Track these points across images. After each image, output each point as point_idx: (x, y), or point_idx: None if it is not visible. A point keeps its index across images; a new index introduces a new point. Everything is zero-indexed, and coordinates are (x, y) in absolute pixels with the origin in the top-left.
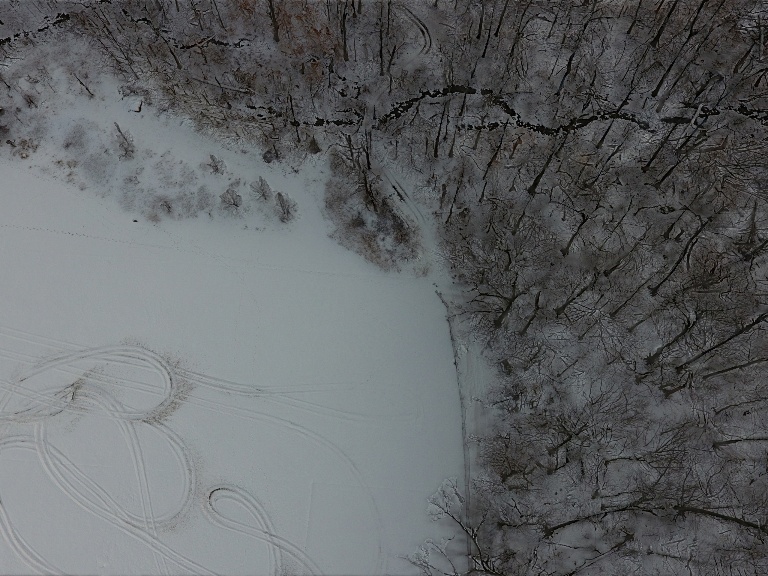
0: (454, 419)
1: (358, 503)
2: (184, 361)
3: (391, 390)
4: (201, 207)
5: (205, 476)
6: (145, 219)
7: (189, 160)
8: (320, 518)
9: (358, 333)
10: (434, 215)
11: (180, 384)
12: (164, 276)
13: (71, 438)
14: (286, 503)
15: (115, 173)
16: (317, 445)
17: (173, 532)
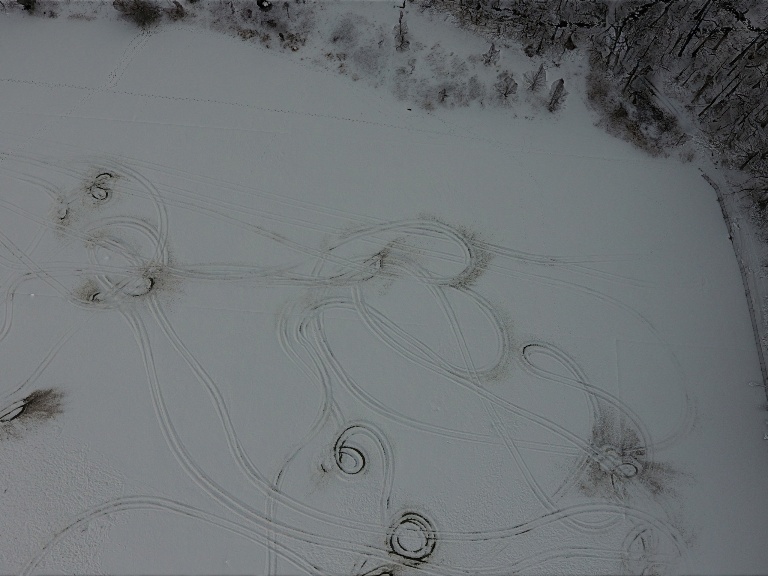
0: (737, 287)
1: (661, 358)
2: (479, 234)
3: (675, 261)
4: (472, 97)
5: (516, 334)
6: (419, 107)
7: (458, 53)
8: (628, 370)
9: (636, 211)
10: (687, 108)
11: (479, 254)
12: (446, 159)
13: (386, 300)
14: (595, 357)
15: (387, 64)
16: (615, 308)
17: (495, 381)
